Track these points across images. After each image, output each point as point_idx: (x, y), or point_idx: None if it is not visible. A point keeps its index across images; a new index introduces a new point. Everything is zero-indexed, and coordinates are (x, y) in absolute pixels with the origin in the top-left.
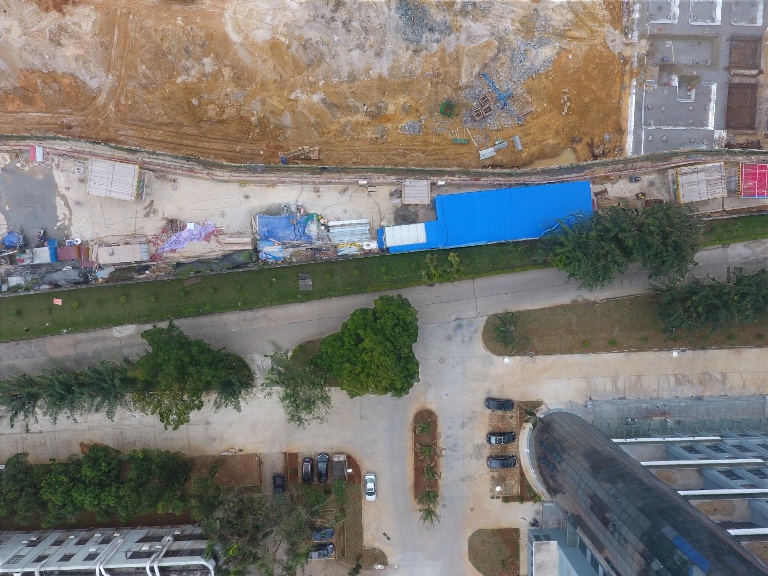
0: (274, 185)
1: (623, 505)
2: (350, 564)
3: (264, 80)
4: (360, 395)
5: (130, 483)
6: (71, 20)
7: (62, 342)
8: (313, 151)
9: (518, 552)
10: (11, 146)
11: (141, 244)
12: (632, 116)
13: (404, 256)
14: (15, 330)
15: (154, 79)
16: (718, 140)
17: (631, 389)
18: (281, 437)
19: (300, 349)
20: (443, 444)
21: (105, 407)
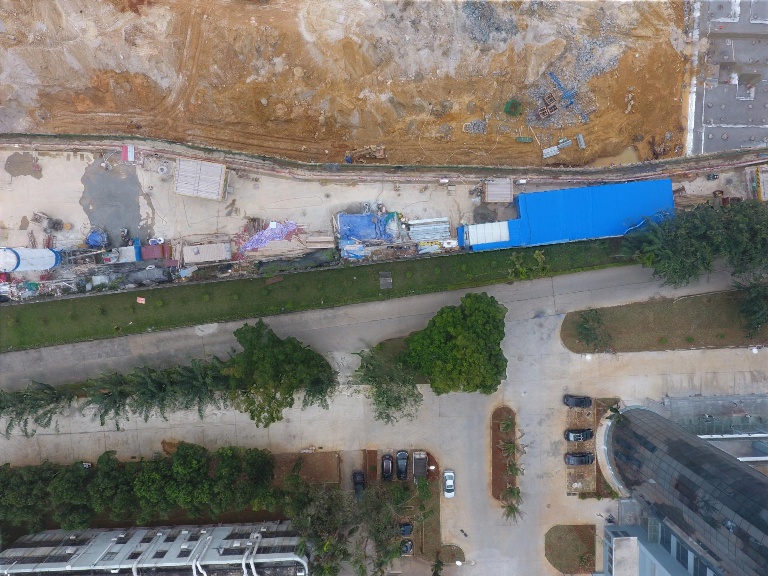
0: (355, 184)
1: (739, 500)
2: (428, 561)
3: (334, 79)
4: (446, 392)
5: (223, 480)
6: (146, 20)
7: (145, 341)
8: (379, 150)
9: (594, 548)
10: (95, 146)
11: (225, 243)
12: (692, 114)
13: (484, 254)
14: (99, 329)
15: (224, 79)
16: None
17: (707, 386)
18: (360, 434)
19: (381, 347)
20: (521, 441)
21: (194, 405)
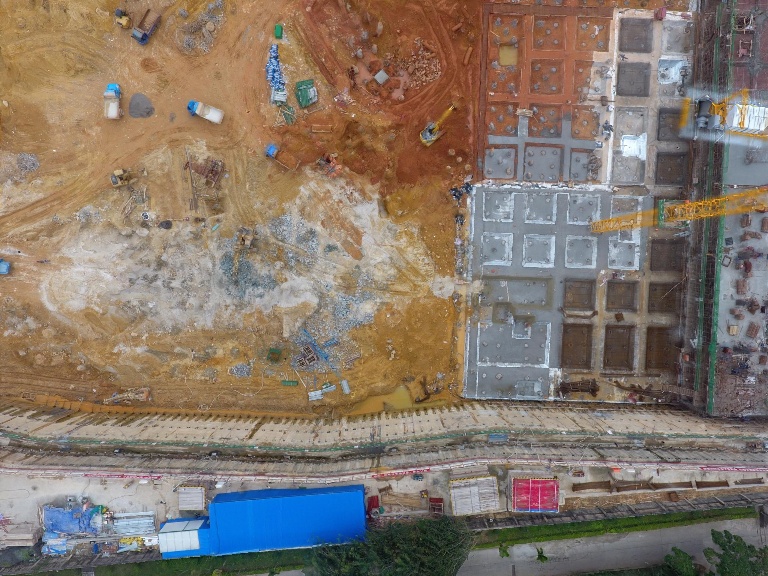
0: (62, 477)
1: None
2: None
3: (85, 338)
4: None
5: None
6: None
7: None
8: None
9: None
10: None
11: None
12: (467, 353)
13: None
14: None
15: None
16: (553, 378)
17: None
18: None
19: None
20: None
21: None
